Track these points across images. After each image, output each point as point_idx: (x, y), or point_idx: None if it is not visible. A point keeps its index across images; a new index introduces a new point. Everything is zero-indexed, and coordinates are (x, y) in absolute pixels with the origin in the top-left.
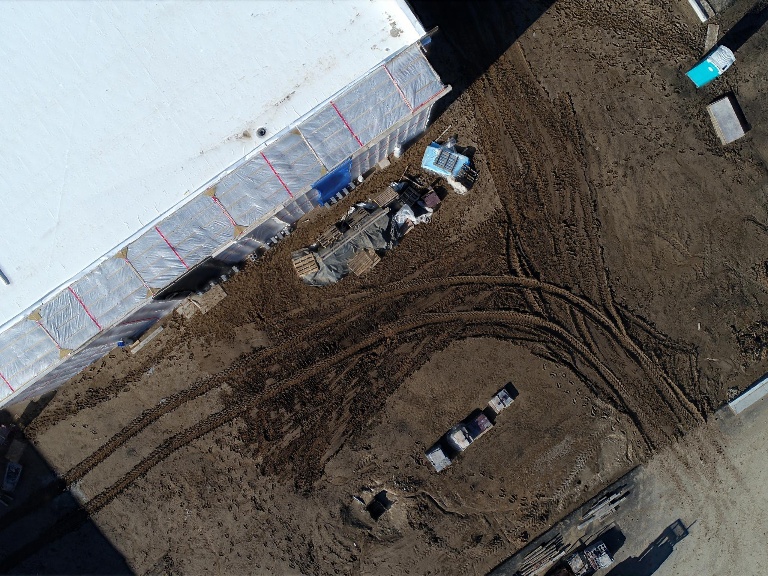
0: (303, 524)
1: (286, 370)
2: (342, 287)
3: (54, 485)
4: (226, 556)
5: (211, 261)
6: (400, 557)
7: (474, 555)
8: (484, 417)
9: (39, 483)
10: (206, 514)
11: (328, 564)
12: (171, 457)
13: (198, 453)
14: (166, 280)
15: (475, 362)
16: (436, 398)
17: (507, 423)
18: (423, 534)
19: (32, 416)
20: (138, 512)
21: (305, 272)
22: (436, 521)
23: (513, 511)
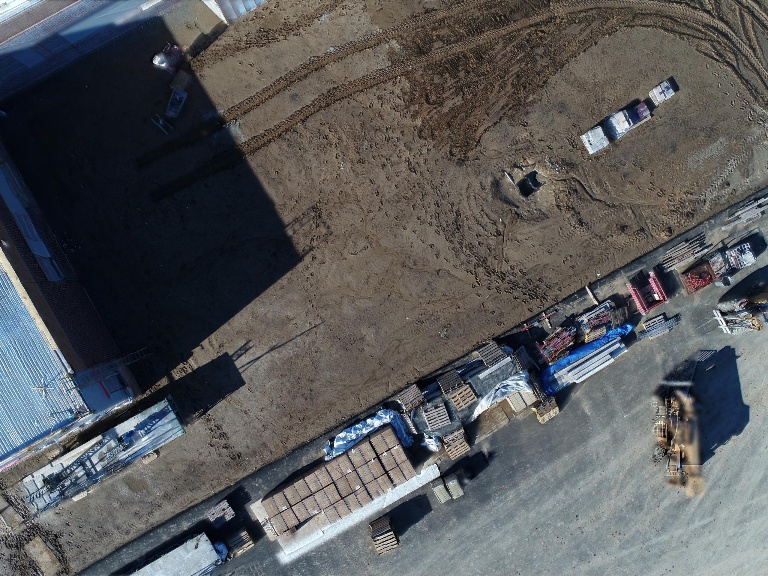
0: (453, 192)
1: (454, 35)
2: None
3: (214, 121)
4: (374, 214)
5: None
6: (544, 237)
7: (616, 244)
8: (644, 105)
9: (200, 116)
10: (359, 169)
11: (473, 235)
12: (332, 107)
13: (359, 107)
14: None
15: (640, 52)
16: (597, 83)
17: (664, 117)
18: (569, 217)
19: (201, 48)
20: (293, 158)
21: None
22: (583, 206)
23: (660, 206)
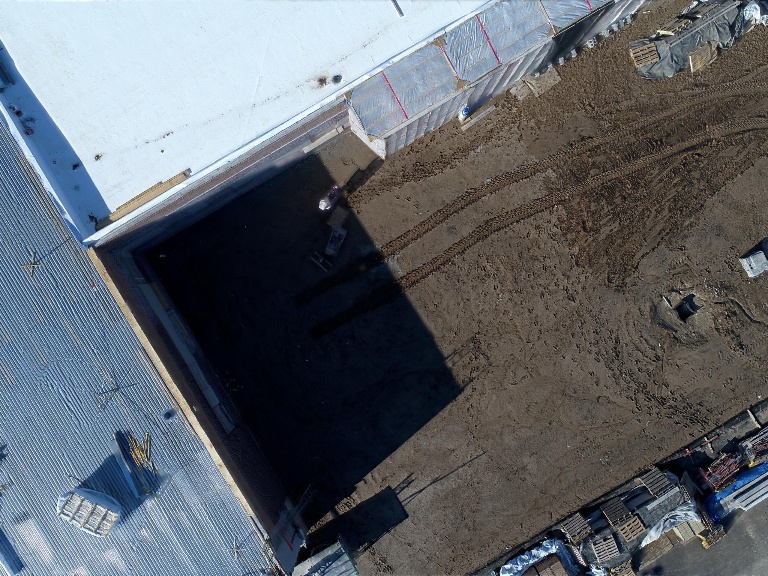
0: (612, 319)
1: (611, 162)
2: (675, 83)
3: (372, 256)
4: (533, 343)
5: (609, 8)
6: (704, 361)
7: None
8: None
9: (358, 252)
10: (518, 299)
11: (632, 361)
12: (489, 239)
13: (516, 237)
14: (569, 20)
15: None
16: (755, 205)
17: None
18: (729, 340)
19: (358, 184)
20: (452, 291)
21: (644, 62)
22: (743, 328)
23: None
